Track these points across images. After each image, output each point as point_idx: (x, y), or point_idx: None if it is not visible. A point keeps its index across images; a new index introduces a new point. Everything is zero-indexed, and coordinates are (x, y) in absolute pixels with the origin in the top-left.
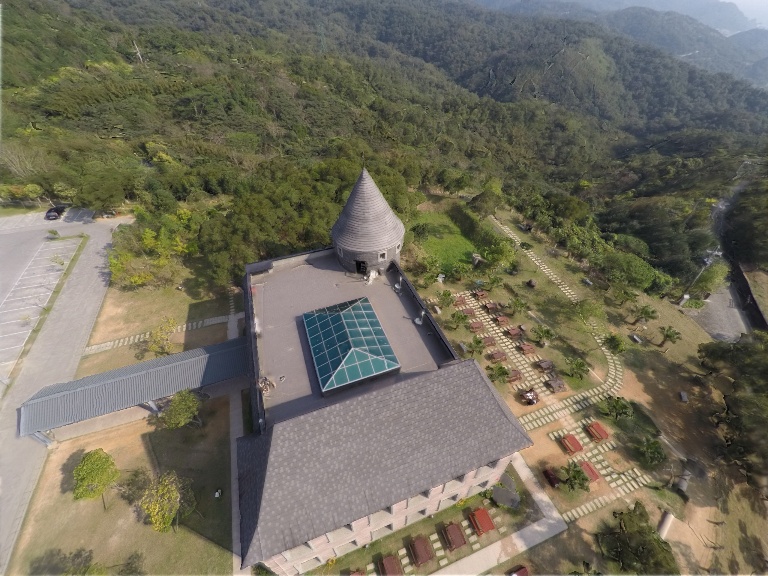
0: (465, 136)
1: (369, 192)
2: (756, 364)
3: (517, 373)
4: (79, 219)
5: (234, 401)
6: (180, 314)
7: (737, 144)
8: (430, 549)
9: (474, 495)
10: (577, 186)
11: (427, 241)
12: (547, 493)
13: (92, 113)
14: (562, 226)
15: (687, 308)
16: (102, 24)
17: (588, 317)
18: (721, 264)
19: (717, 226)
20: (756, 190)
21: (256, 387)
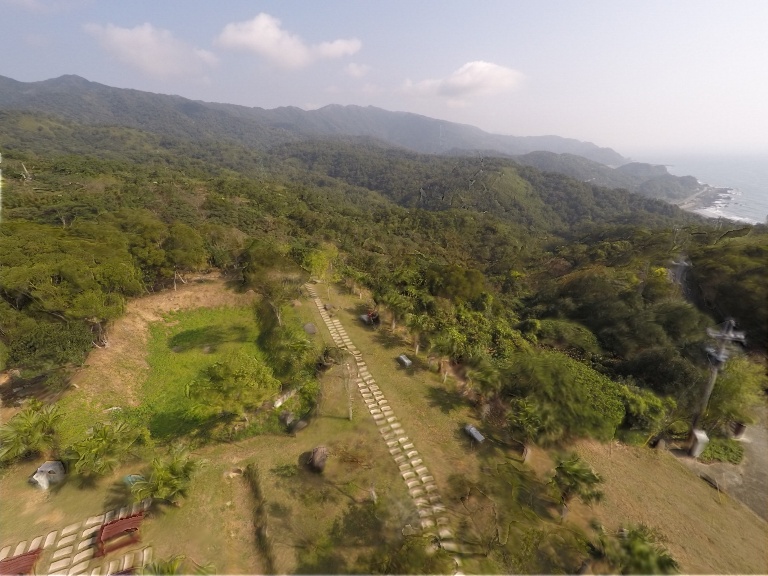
0: (395, 241)
1: None
2: None
3: None
4: None
5: None
6: None
7: None
8: None
9: None
10: (509, 277)
11: (172, 361)
12: None
13: None
14: (434, 311)
15: (712, 464)
16: None
17: None
18: (746, 360)
19: (695, 292)
20: (711, 252)
21: None
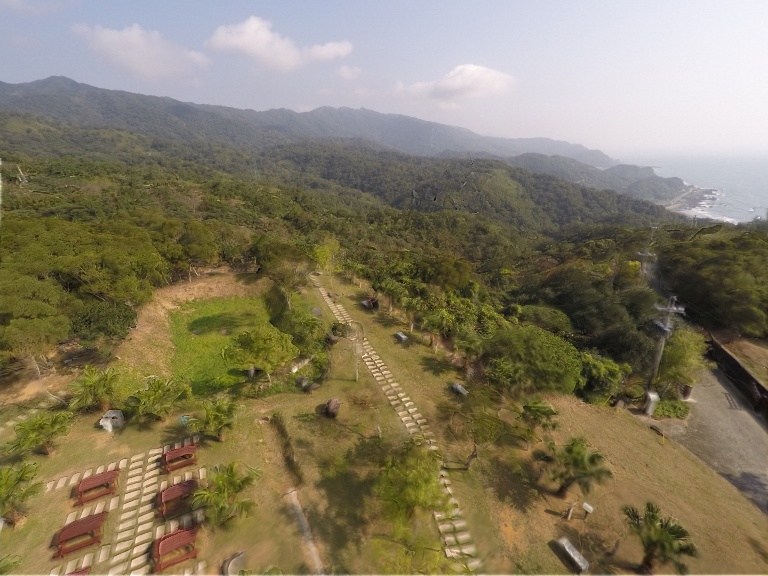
0: (388, 241)
1: None
2: None
3: None
4: None
5: None
6: None
7: None
8: None
9: None
10: None
11: (194, 341)
12: None
13: None
14: (426, 296)
15: (663, 420)
16: None
17: (411, 510)
18: (689, 330)
19: (656, 278)
20: (681, 247)
21: None
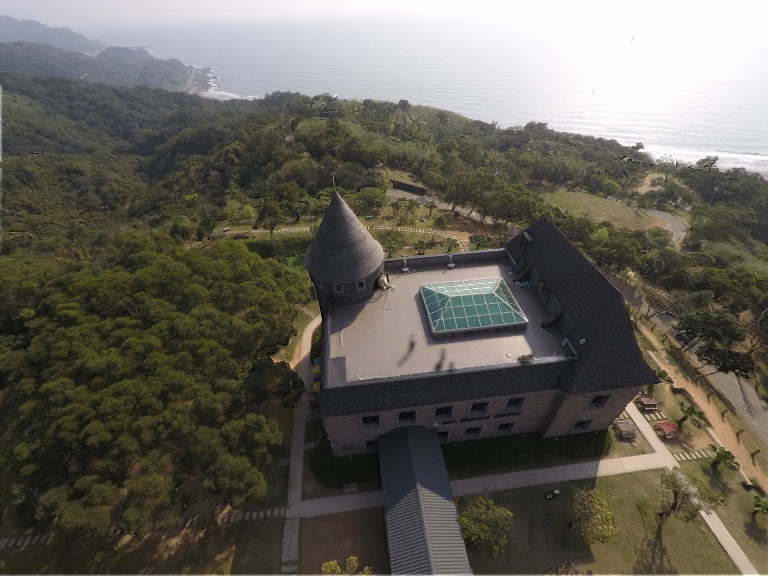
0: None
1: None
2: (471, 185)
3: None
4: None
5: None
6: None
7: (227, 127)
8: None
9: None
10: None
11: None
12: None
13: None
14: (308, 203)
15: None
16: None
17: (414, 222)
18: (382, 170)
19: (349, 157)
20: (315, 137)
21: (532, 364)
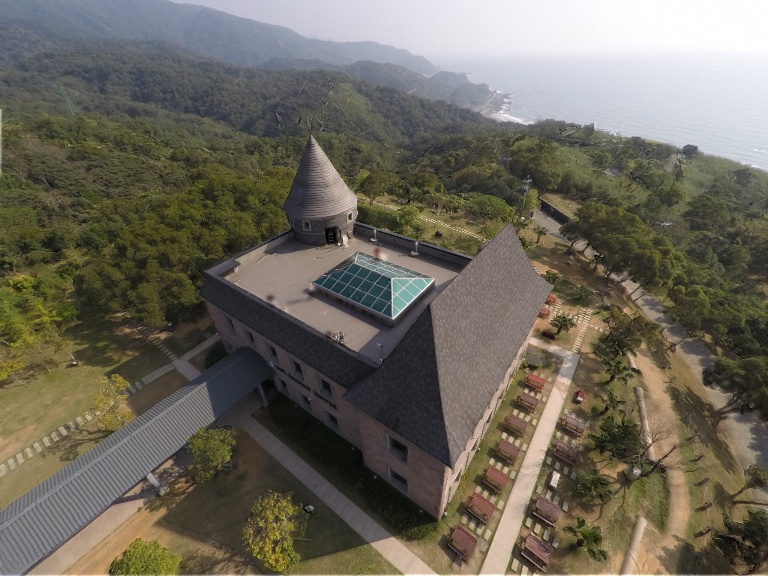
0: None
1: (322, 157)
2: (596, 220)
3: None
4: None
5: (251, 428)
6: (98, 388)
7: None
8: (520, 420)
9: None
10: None
11: None
12: (554, 344)
13: None
14: (429, 193)
15: None
16: None
17: (494, 235)
18: (532, 189)
19: (514, 170)
20: (513, 152)
21: (331, 342)
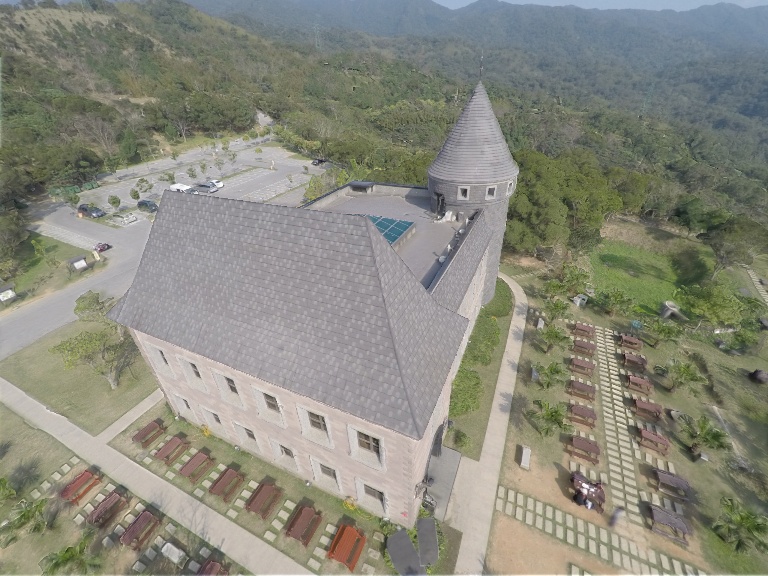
0: None
1: (475, 109)
2: None
3: (592, 449)
4: (327, 168)
5: None
6: None
7: None
8: (273, 509)
9: (372, 514)
10: None
11: (608, 271)
12: None
13: (399, 129)
14: None
15: None
16: (444, 77)
17: None
18: None
19: None
20: None
21: None
